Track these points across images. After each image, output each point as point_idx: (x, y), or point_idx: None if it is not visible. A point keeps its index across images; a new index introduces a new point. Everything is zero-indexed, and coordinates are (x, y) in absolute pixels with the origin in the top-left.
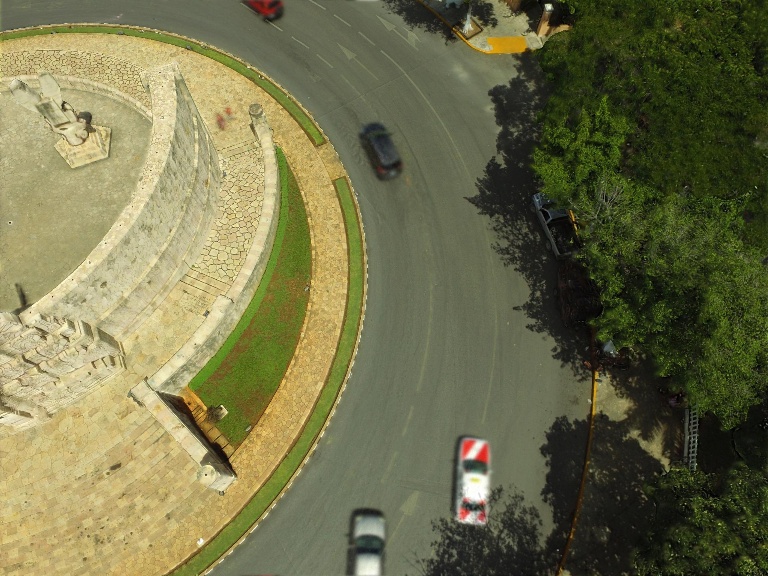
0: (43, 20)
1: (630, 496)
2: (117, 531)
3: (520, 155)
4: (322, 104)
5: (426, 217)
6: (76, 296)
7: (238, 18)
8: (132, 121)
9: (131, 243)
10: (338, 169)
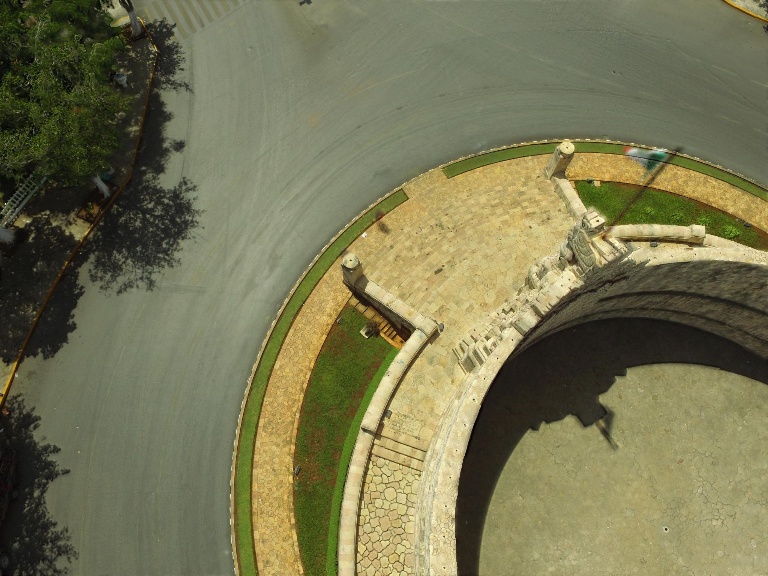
0: None
1: (7, 296)
2: (428, 233)
3: None
4: None
5: None
6: None
7: None
8: None
9: None
10: None
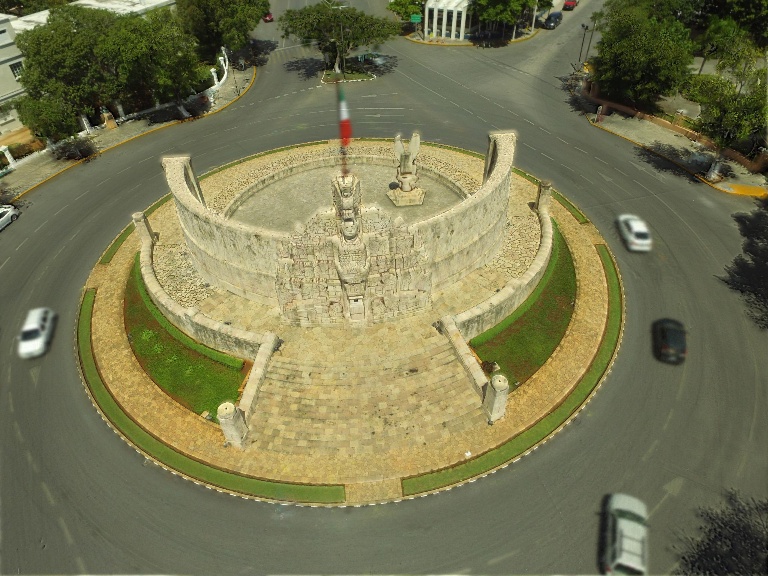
0: (388, 136)
1: None
2: (403, 420)
3: (767, 257)
4: (584, 201)
5: (678, 281)
6: (438, 229)
7: (521, 150)
8: (440, 189)
9: (476, 212)
10: (598, 239)
